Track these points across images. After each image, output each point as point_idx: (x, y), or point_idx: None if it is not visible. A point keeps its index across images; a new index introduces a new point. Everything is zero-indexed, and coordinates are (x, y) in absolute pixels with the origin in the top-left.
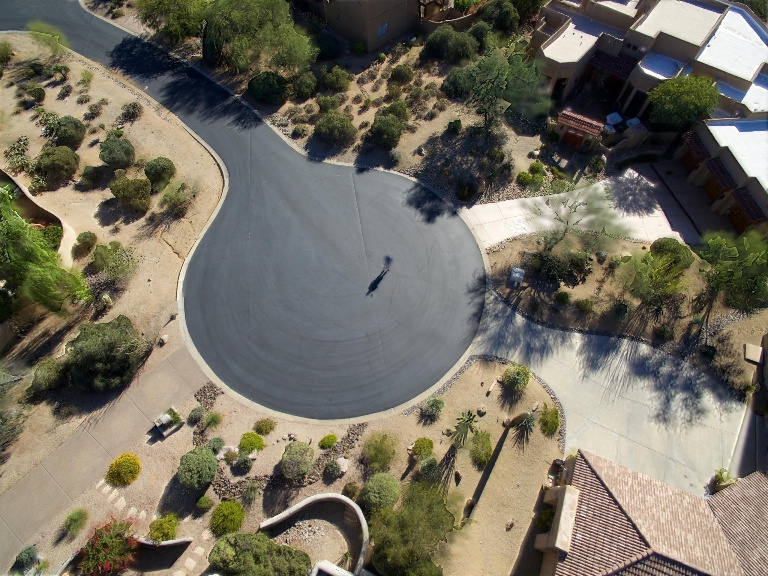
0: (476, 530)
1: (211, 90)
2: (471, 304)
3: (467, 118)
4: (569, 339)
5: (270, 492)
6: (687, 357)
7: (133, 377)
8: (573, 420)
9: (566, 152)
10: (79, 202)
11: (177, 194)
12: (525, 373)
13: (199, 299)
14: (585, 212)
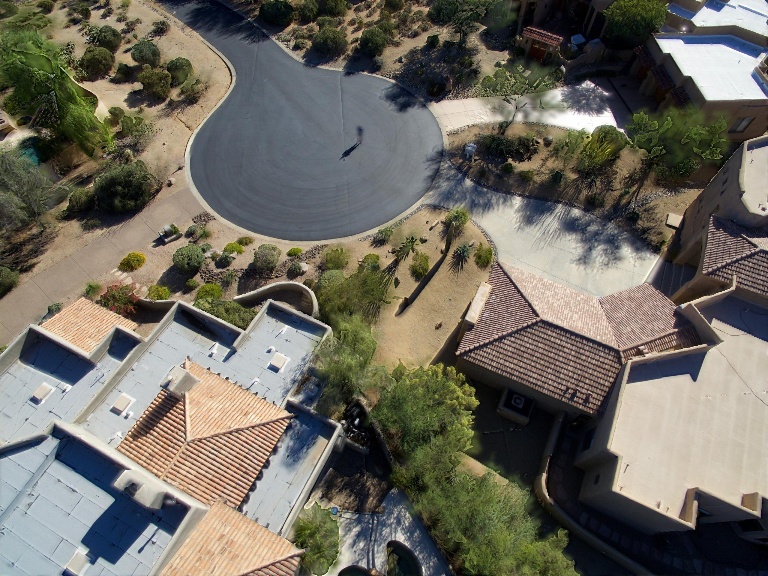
0: (408, 322)
1: (228, 15)
2: (427, 169)
3: (445, 36)
4: (510, 200)
5: (244, 280)
6: (614, 220)
7: (145, 205)
8: (505, 259)
9: (531, 65)
10: (113, 90)
11: (192, 85)
12: (463, 213)
13: (203, 157)
14: (540, 109)
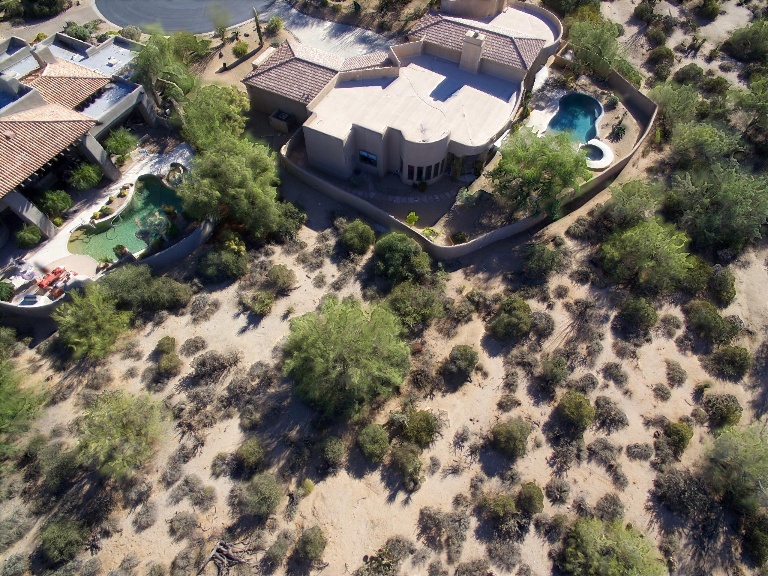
0: (225, 79)
1: None
2: (266, 2)
3: None
4: (322, 23)
5: None
6: (395, 38)
7: (58, 15)
8: None
9: None
10: None
11: None
12: (278, 20)
13: None
14: None
